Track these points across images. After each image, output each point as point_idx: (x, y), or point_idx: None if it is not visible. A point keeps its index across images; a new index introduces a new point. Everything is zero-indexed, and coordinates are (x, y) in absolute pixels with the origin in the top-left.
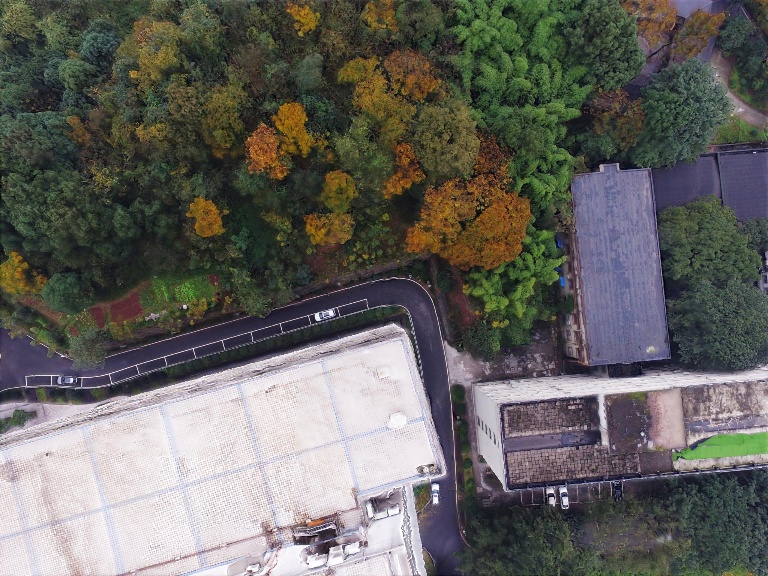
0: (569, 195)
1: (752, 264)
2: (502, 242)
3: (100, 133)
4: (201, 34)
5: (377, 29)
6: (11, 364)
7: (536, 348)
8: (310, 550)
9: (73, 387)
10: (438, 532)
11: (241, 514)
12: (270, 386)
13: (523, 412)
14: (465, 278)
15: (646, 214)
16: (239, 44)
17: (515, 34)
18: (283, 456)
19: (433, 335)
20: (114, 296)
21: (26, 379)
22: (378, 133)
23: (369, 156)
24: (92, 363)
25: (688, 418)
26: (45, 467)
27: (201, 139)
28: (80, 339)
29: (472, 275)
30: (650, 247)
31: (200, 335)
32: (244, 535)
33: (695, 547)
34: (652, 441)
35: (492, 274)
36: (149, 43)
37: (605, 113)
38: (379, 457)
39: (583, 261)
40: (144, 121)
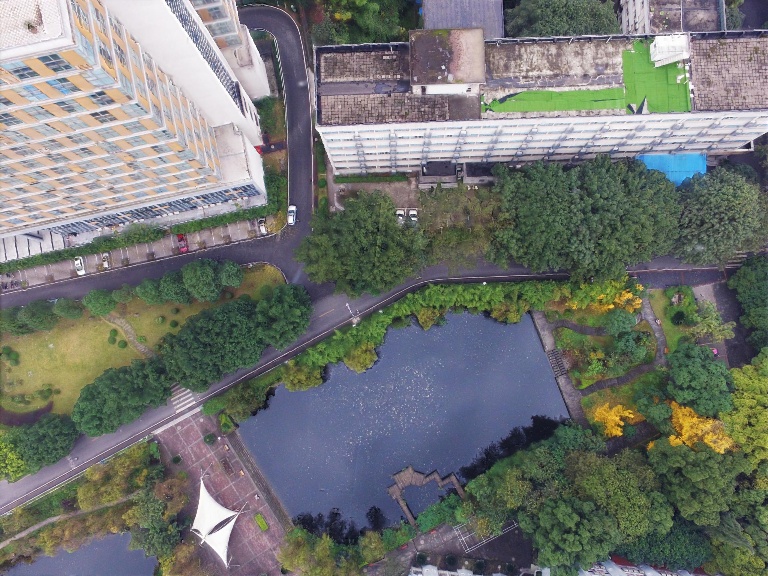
0: None
1: None
2: None
3: None
4: None
5: None
6: None
7: None
8: None
9: None
10: (293, 254)
11: None
12: None
13: (339, 59)
14: None
15: None
16: None
17: None
18: None
19: (297, 62)
20: None
21: None
22: None
23: None
24: None
25: (499, 74)
26: None
27: None
28: None
29: None
30: None
31: None
32: None
33: (518, 232)
34: (452, 75)
35: None
36: None
37: None
38: None
39: None
40: None
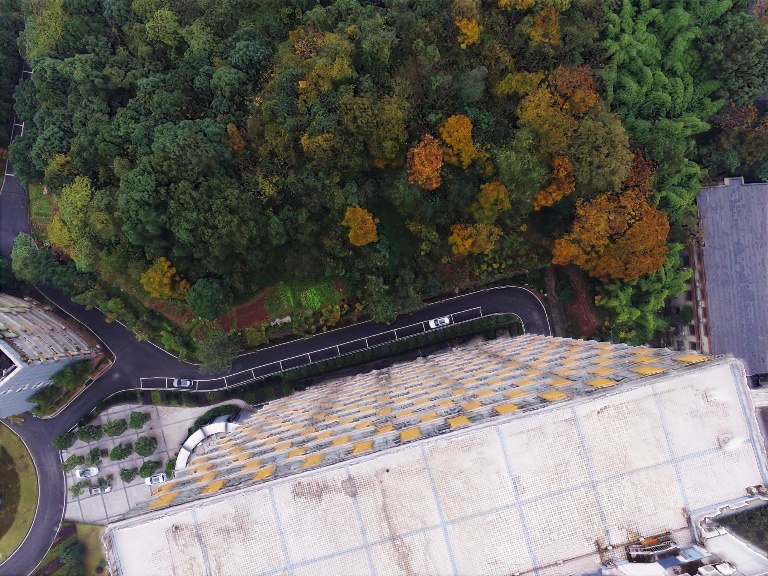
0: (695, 208)
1: None
2: (647, 255)
3: (256, 141)
4: (380, 46)
5: None
6: (126, 366)
7: None
8: (677, 570)
9: (188, 390)
10: None
11: (576, 532)
12: (602, 407)
13: None
14: (595, 289)
15: None
16: (400, 55)
17: (655, 48)
18: (615, 475)
19: None
20: (241, 301)
21: (141, 381)
22: (538, 146)
23: (527, 168)
24: (223, 367)
25: None
26: (386, 483)
27: (366, 149)
28: (213, 343)
29: (607, 286)
30: None
31: (315, 340)
32: (579, 552)
33: None
34: None
35: (626, 285)
36: (319, 54)
37: (735, 127)
38: (709, 478)
39: (708, 273)
40: (307, 130)
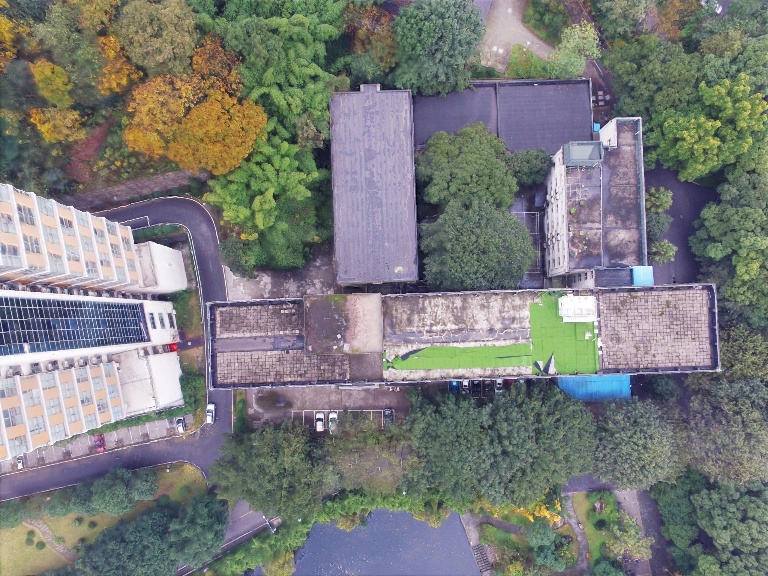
0: (327, 113)
1: (503, 188)
2: (218, 143)
3: None
4: None
5: None
6: None
7: (316, 274)
8: None
9: None
10: (213, 452)
11: None
12: None
13: (236, 314)
14: (211, 188)
15: (403, 135)
16: None
17: None
18: None
19: (213, 256)
20: None
21: None
22: None
23: (74, 47)
24: None
25: (402, 329)
26: None
27: None
28: None
29: (208, 181)
30: (405, 168)
31: None
32: None
33: (430, 468)
34: (348, 344)
35: (230, 182)
36: None
37: (359, 30)
38: None
39: (337, 179)
40: None
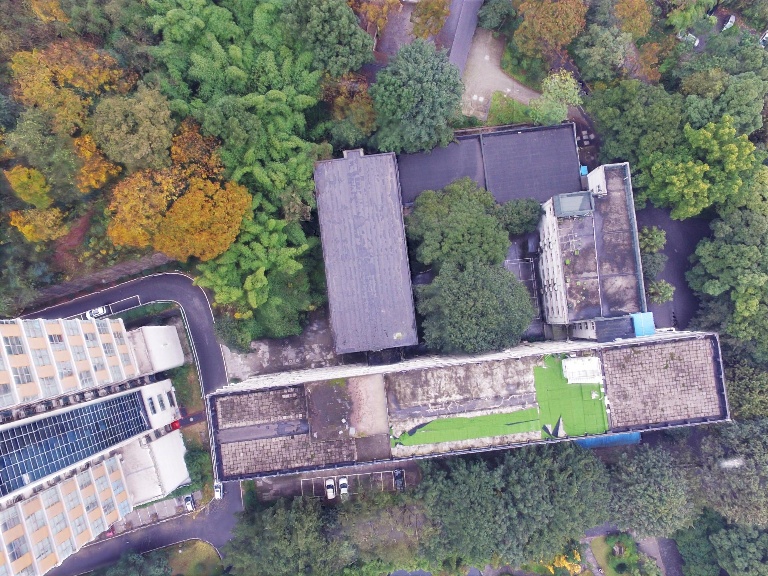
0: (312, 183)
1: (496, 245)
2: (204, 232)
3: None
4: None
5: (49, 22)
6: None
7: (314, 339)
8: None
9: None
10: (224, 527)
11: None
12: None
13: (236, 403)
14: None
15: (391, 199)
16: None
17: (228, 22)
18: None
19: (208, 329)
20: None
21: None
22: None
23: (49, 150)
24: None
25: (406, 403)
26: None
27: None
28: None
29: (197, 267)
30: (396, 232)
31: None
32: None
33: (445, 535)
34: (354, 428)
35: (219, 265)
36: None
37: (338, 98)
38: None
39: (328, 249)
40: None
